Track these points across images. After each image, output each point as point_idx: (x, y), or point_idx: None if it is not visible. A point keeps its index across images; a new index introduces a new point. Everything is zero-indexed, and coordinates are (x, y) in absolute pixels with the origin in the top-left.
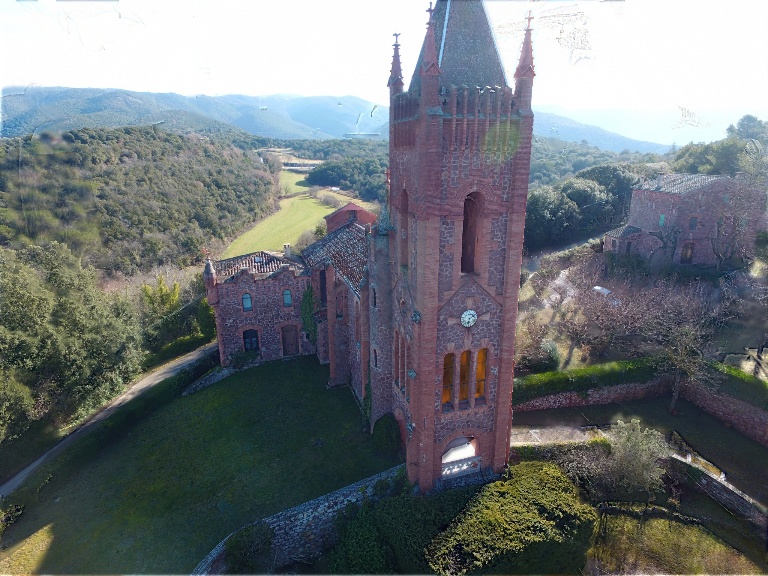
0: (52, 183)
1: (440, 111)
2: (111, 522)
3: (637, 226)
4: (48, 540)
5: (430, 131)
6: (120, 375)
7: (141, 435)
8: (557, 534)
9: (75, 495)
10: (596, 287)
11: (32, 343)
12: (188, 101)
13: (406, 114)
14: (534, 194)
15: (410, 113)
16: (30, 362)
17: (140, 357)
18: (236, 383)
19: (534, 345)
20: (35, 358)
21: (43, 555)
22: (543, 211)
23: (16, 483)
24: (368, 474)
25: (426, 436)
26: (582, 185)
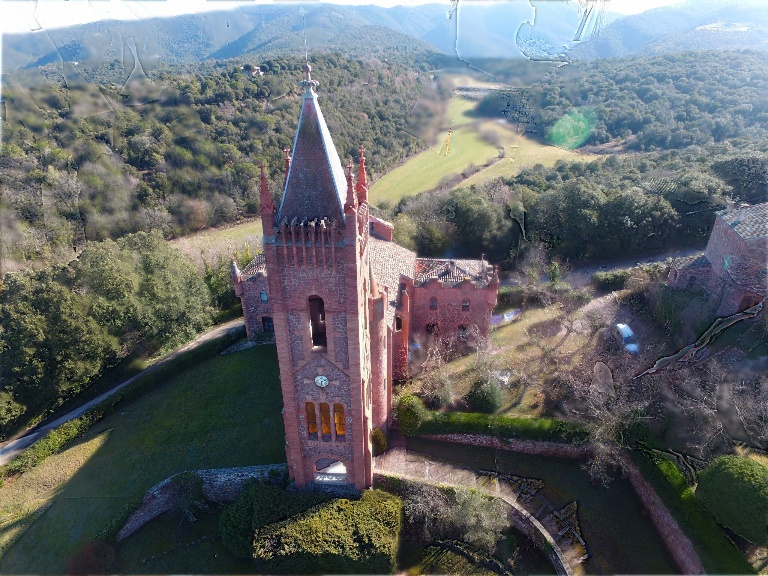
0: (190, 158)
1: (273, 240)
2: (137, 439)
3: (709, 259)
4: (106, 439)
5: (266, 254)
6: (195, 326)
7: (183, 380)
8: (356, 553)
9: (131, 413)
10: (620, 324)
11: (120, 310)
12: (245, 122)
13: None
14: (622, 194)
15: None
16: (119, 321)
17: (213, 314)
18: (252, 355)
19: (479, 384)
20: (123, 319)
21: (100, 448)
22: (623, 217)
23: (112, 393)
24: (277, 460)
25: (294, 453)
26: (700, 184)
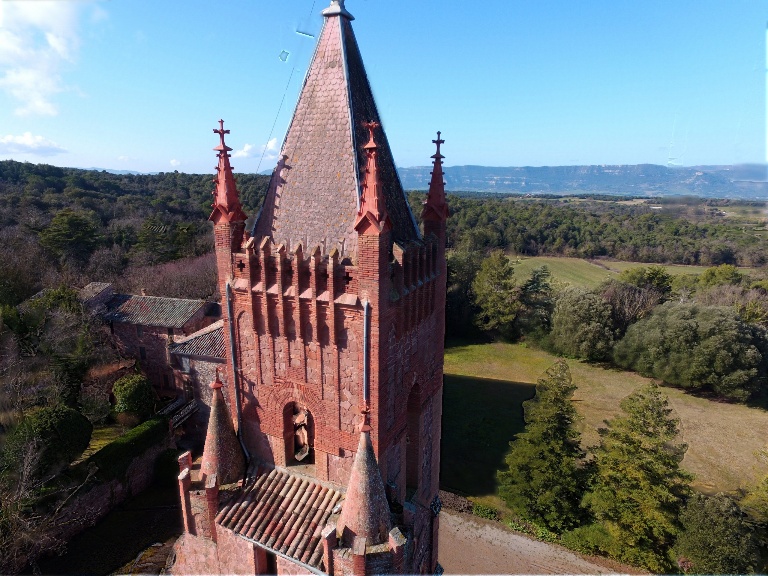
0: None
1: None
2: None
3: None
4: None
5: None
6: None
7: None
8: None
9: None
10: None
11: None
12: None
13: (424, 272)
14: None
15: (430, 269)
16: None
17: None
18: None
19: None
20: None
21: None
22: None
23: None
24: None
25: None
26: None
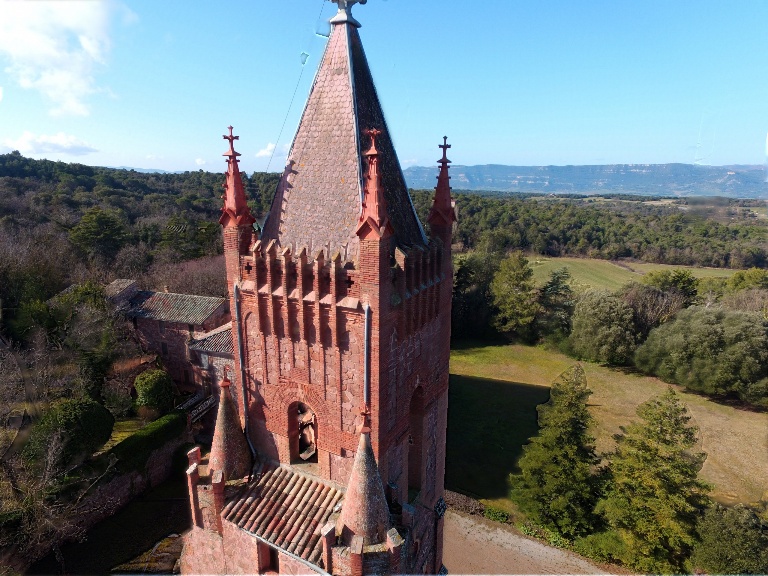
0: None
1: None
2: None
3: None
4: None
5: None
6: None
7: None
8: None
9: None
10: None
11: None
12: None
13: (428, 276)
14: None
15: None
16: None
17: None
18: None
19: None
20: None
21: None
22: None
23: None
24: None
25: None
26: None
